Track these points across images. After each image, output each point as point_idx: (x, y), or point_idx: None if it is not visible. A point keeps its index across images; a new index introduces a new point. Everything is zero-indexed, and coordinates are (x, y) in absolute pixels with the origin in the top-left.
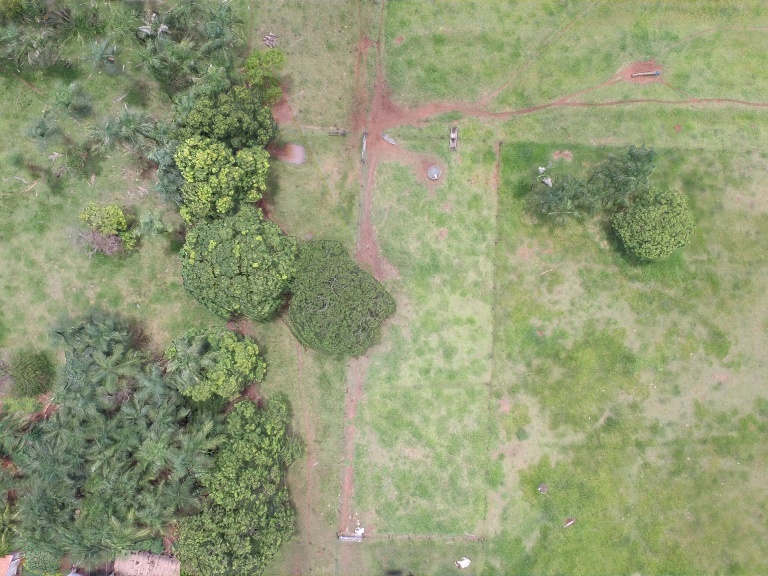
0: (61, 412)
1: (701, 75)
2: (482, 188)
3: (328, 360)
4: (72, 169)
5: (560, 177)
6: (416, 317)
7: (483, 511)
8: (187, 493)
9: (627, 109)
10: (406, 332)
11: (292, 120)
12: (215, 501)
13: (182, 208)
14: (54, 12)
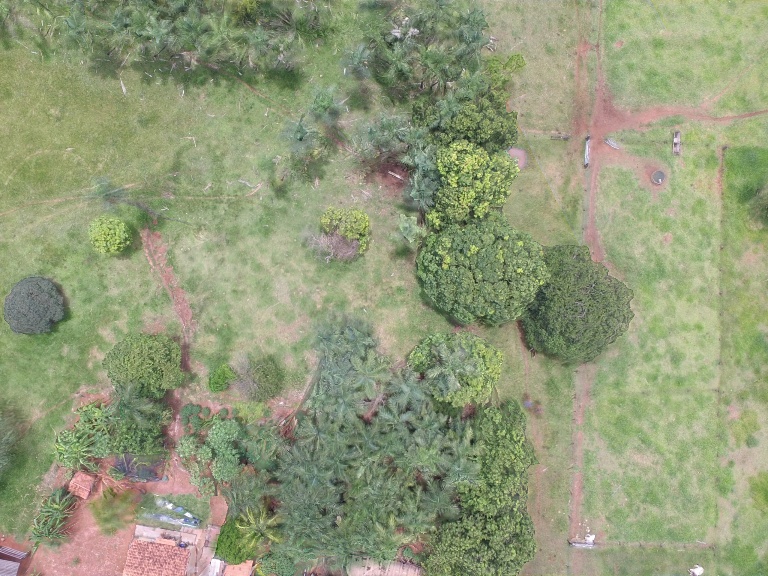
0: (320, 417)
1: None
2: (705, 193)
3: (556, 366)
4: (295, 173)
5: None
6: (643, 323)
7: (714, 518)
8: (448, 499)
9: None
10: (633, 338)
11: None
12: (475, 508)
13: (432, 213)
14: (275, 15)
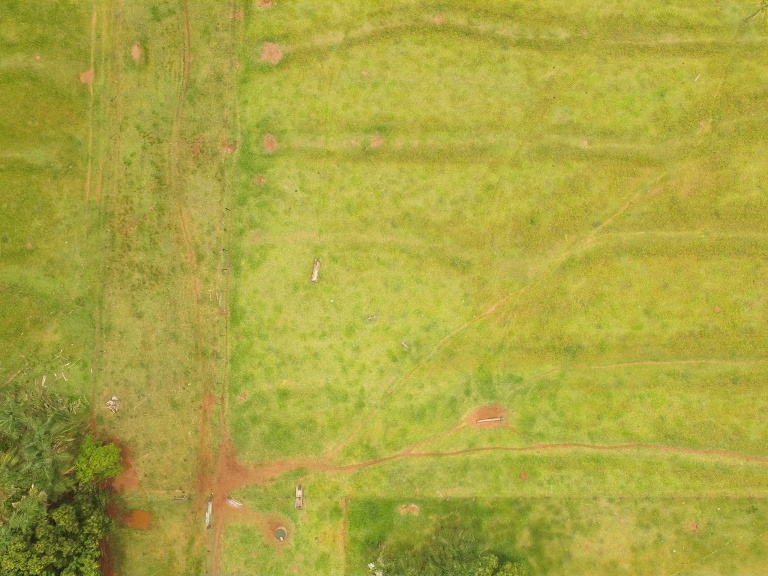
0: None
1: (546, 418)
2: (329, 546)
3: None
4: None
5: (407, 533)
6: None
7: None
8: None
9: (472, 458)
10: None
11: (137, 485)
12: None
13: None
14: None
